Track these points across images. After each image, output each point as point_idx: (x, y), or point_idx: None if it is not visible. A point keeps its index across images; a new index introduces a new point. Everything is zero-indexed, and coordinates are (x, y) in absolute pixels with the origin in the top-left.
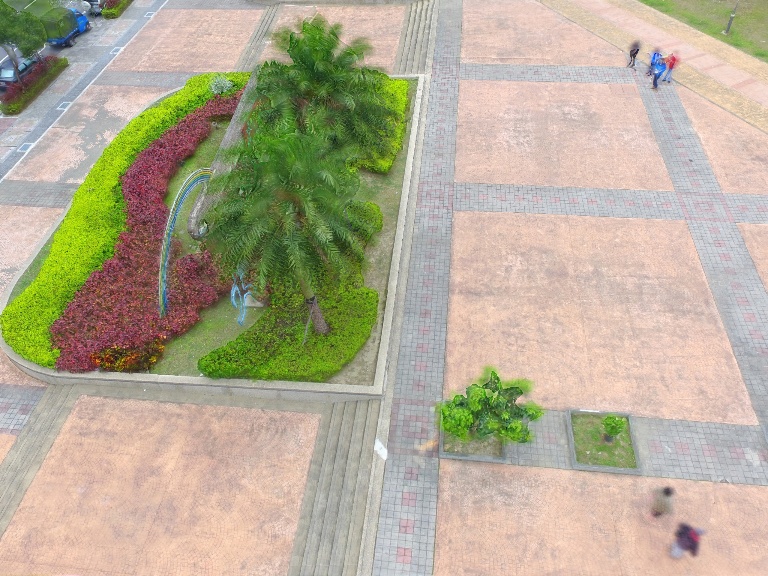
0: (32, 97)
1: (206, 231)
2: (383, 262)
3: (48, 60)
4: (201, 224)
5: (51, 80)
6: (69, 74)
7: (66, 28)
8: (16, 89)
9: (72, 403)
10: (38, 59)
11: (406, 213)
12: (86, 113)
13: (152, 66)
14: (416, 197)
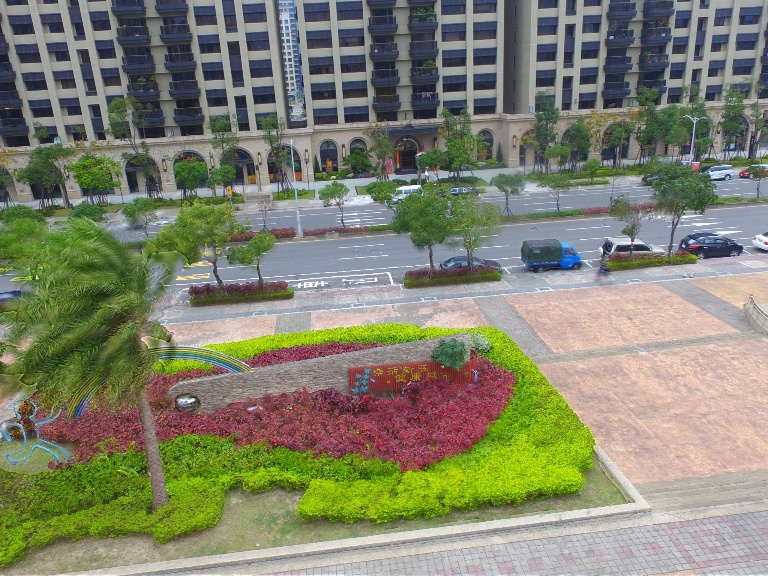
0: (433, 284)
1: (183, 405)
2: (91, 563)
3: (482, 268)
4: (187, 397)
5: (468, 282)
6: (484, 285)
7: (541, 256)
8: (423, 271)
9: (7, 418)
10: (469, 262)
11: (209, 568)
12: (422, 310)
13: (529, 311)
14: (252, 573)
